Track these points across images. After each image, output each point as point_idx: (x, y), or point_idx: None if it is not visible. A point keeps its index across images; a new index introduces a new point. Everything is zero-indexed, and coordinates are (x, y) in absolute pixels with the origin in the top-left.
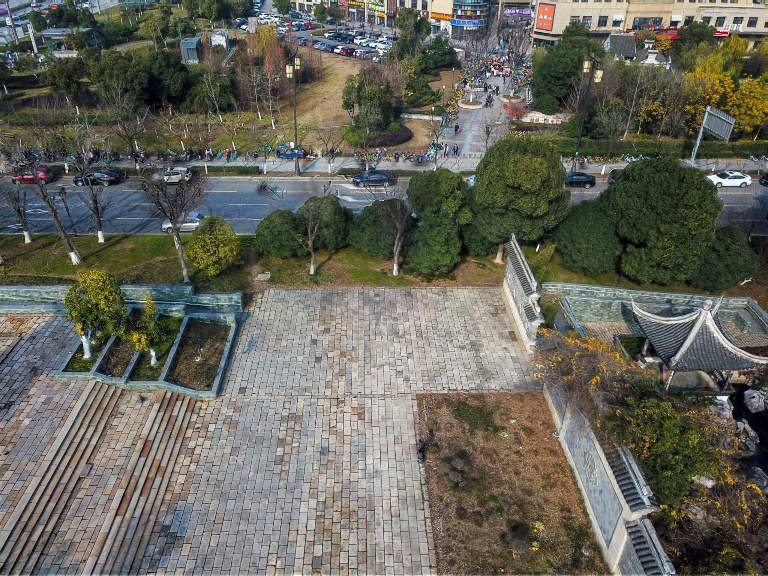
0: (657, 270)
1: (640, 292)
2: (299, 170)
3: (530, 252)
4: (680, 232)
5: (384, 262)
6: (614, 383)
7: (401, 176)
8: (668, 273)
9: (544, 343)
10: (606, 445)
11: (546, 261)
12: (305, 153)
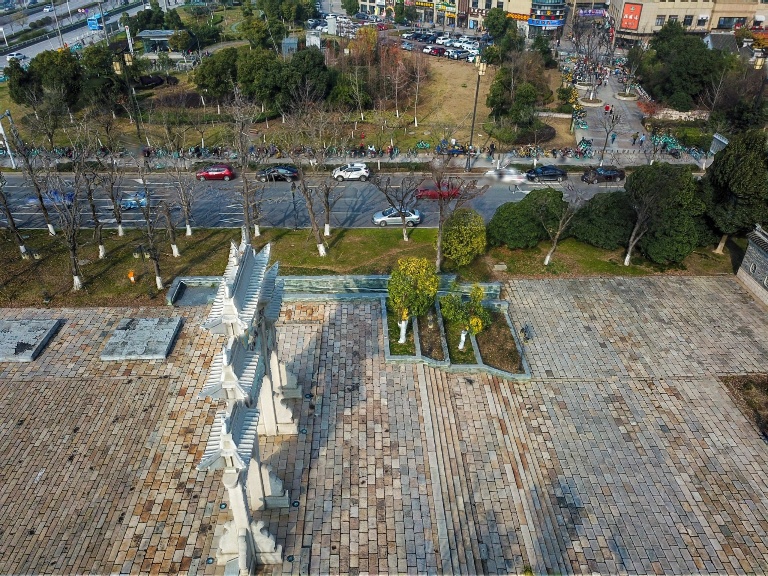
0: None
1: None
2: (470, 166)
3: (743, 243)
4: None
5: (608, 253)
6: None
7: (570, 171)
8: None
9: None
10: None
11: None
12: (464, 150)
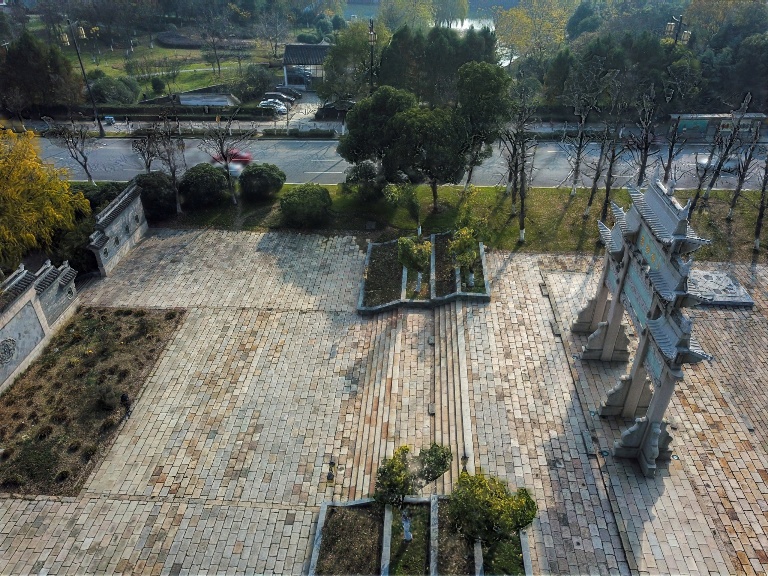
0: None
1: None
2: None
3: None
4: None
5: None
6: None
7: None
8: None
9: None
10: (3, 303)
11: None
12: None
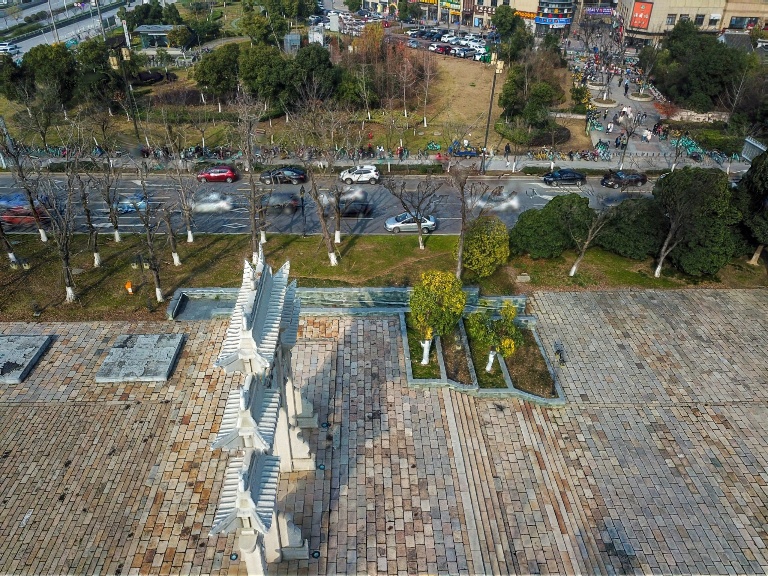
0: None
1: None
2: (484, 169)
3: None
4: None
5: (637, 263)
6: None
7: (588, 175)
8: None
9: None
10: None
11: None
12: (477, 151)
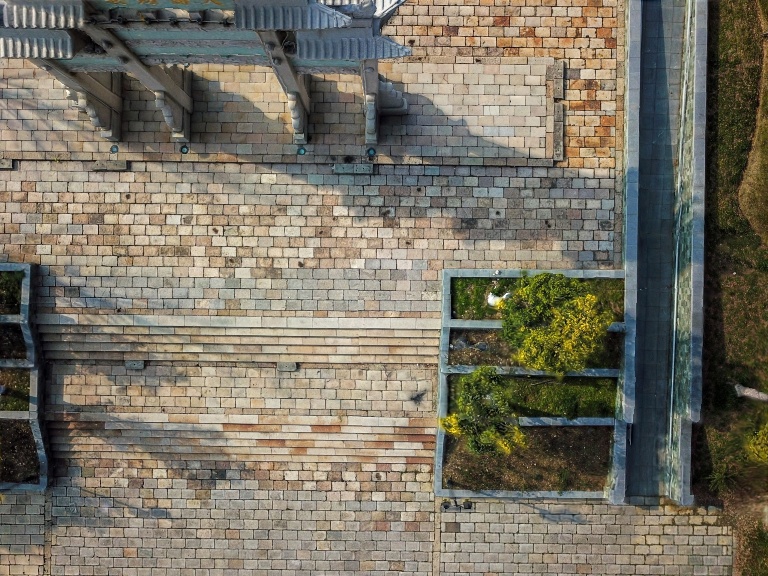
0: None
1: None
2: None
3: None
4: None
5: None
6: None
7: None
8: None
9: None
10: None
11: None
12: None
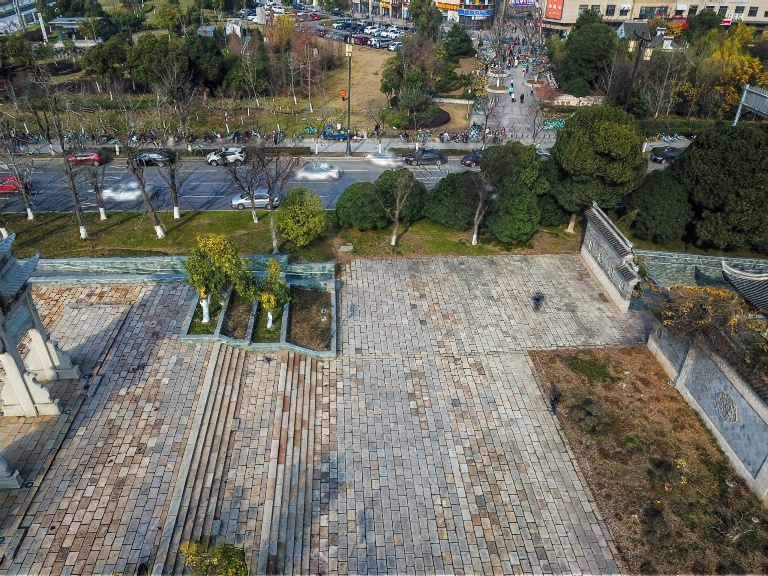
0: (732, 234)
1: (710, 257)
2: (350, 150)
3: None
4: (758, 196)
5: (460, 233)
6: (748, 325)
7: (451, 155)
8: (743, 236)
9: (653, 298)
10: (753, 380)
11: (627, 227)
12: (351, 134)
